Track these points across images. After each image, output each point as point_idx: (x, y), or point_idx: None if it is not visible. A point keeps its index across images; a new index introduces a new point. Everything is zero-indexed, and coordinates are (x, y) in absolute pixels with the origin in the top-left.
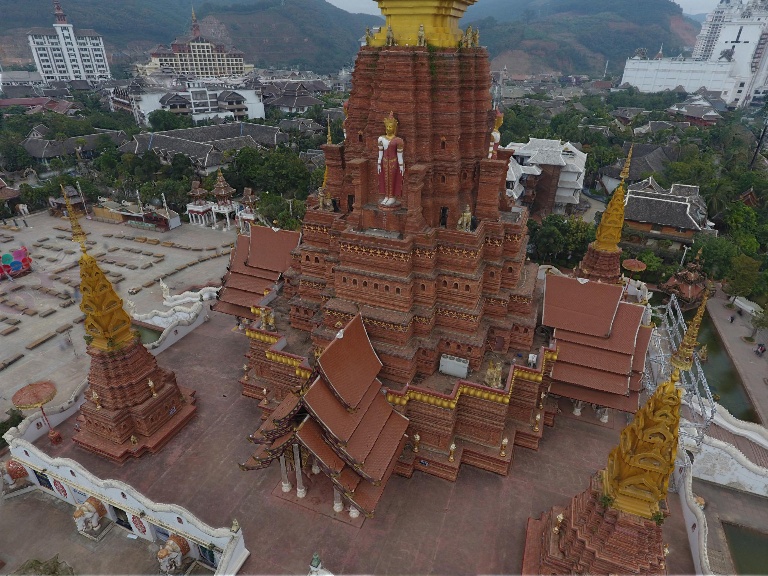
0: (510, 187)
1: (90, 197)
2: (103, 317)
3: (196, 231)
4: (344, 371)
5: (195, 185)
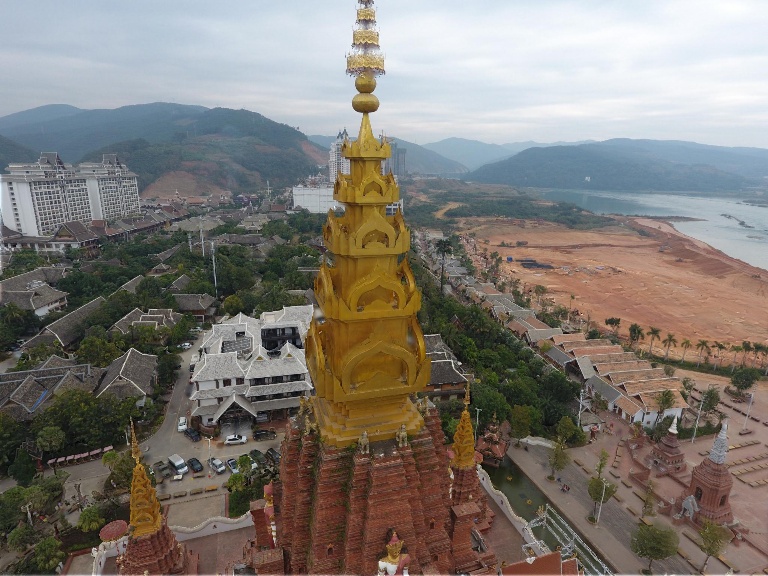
0: (301, 378)
1: None
2: None
3: None
4: None
5: None
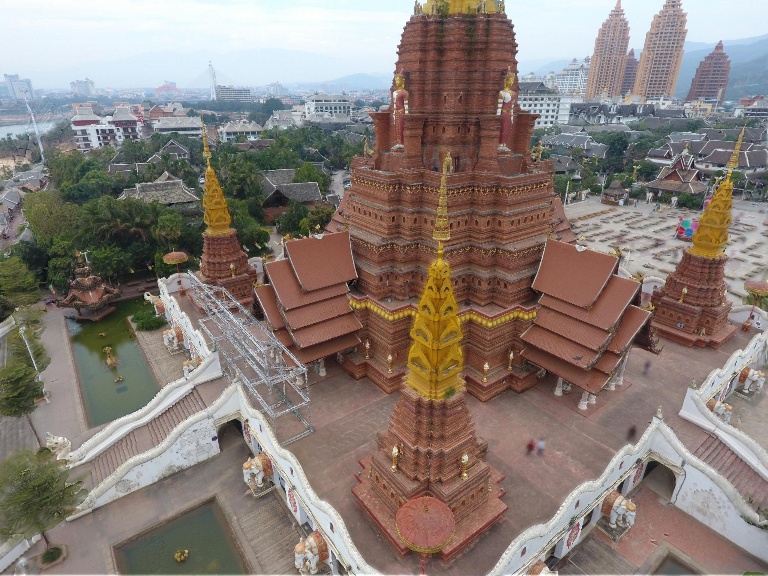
0: None
1: None
2: None
3: None
4: None
5: None
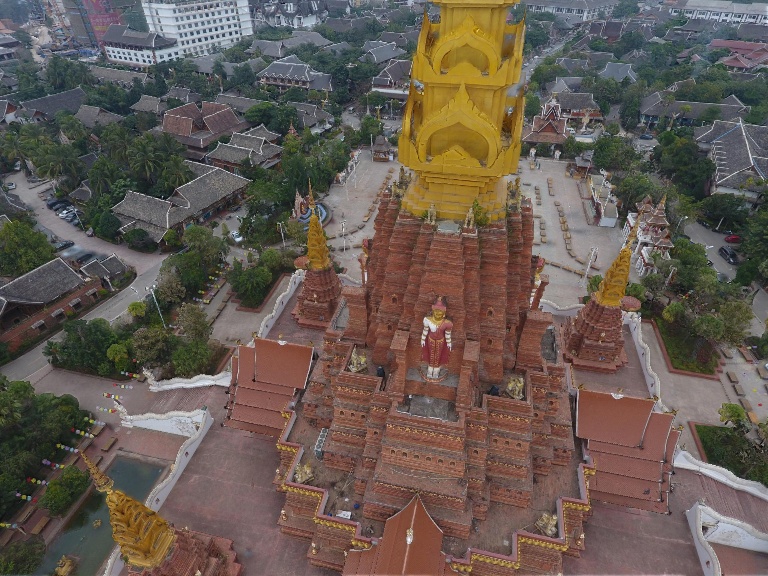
0: None
1: (598, 166)
2: (310, 249)
3: (609, 240)
4: (271, 361)
5: (646, 199)
